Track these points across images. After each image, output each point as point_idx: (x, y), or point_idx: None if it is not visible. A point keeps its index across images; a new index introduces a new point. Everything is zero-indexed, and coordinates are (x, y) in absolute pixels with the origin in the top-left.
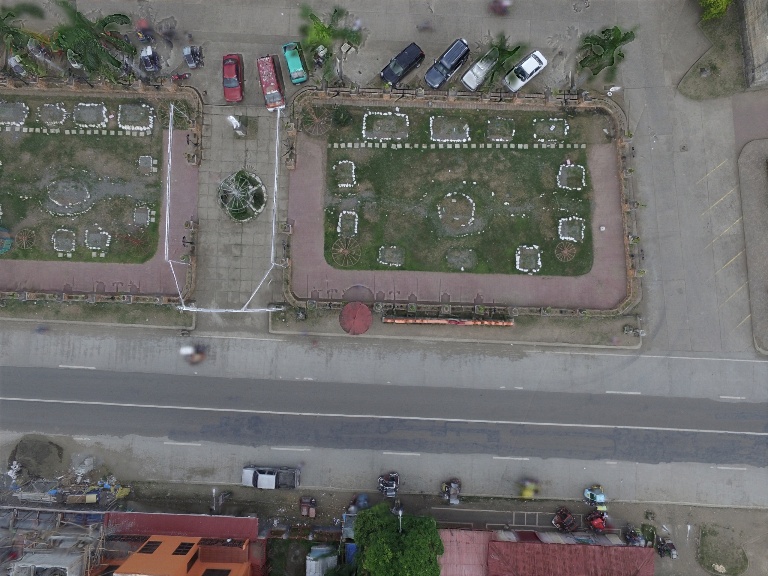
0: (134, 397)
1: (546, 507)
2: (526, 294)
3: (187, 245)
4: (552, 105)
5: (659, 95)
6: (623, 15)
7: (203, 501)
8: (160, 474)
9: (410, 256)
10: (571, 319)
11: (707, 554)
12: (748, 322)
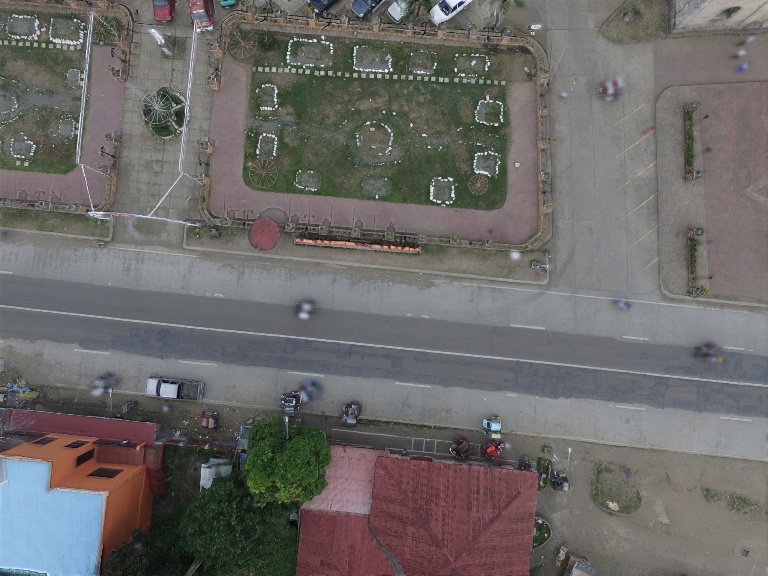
0: (48, 303)
1: (445, 435)
2: (438, 225)
3: (109, 159)
4: (475, 41)
5: (582, 37)
6: None
7: (109, 409)
8: (69, 380)
9: (326, 181)
10: (480, 251)
11: (601, 491)
12: (656, 265)
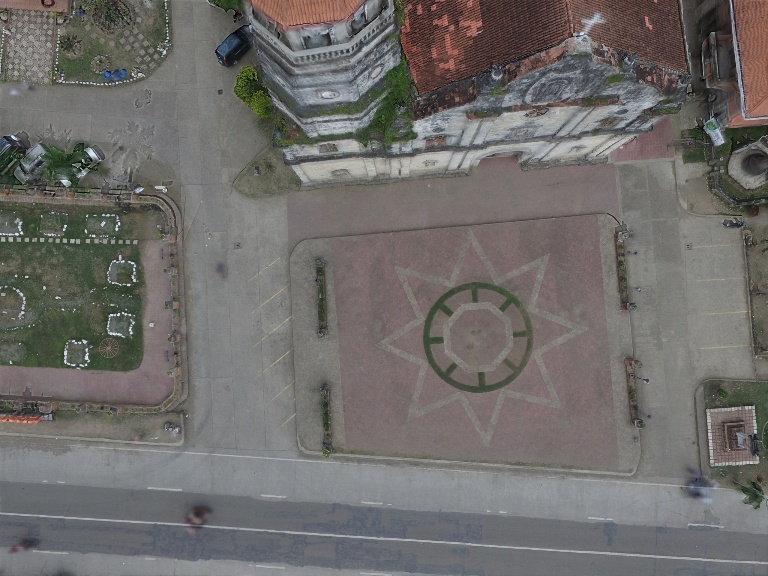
0: None
1: None
2: (75, 388)
3: None
4: (106, 201)
5: (215, 192)
6: (183, 112)
7: None
8: None
9: None
10: None
11: None
12: (293, 421)
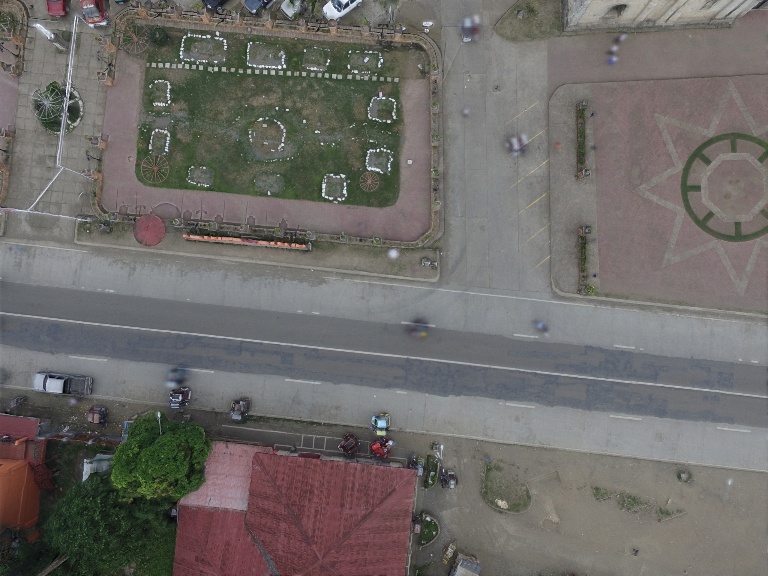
0: None
1: (335, 432)
2: (330, 222)
3: (2, 153)
4: (369, 38)
5: (476, 35)
6: None
7: None
8: None
9: (219, 177)
10: (371, 248)
11: (491, 489)
12: (547, 263)
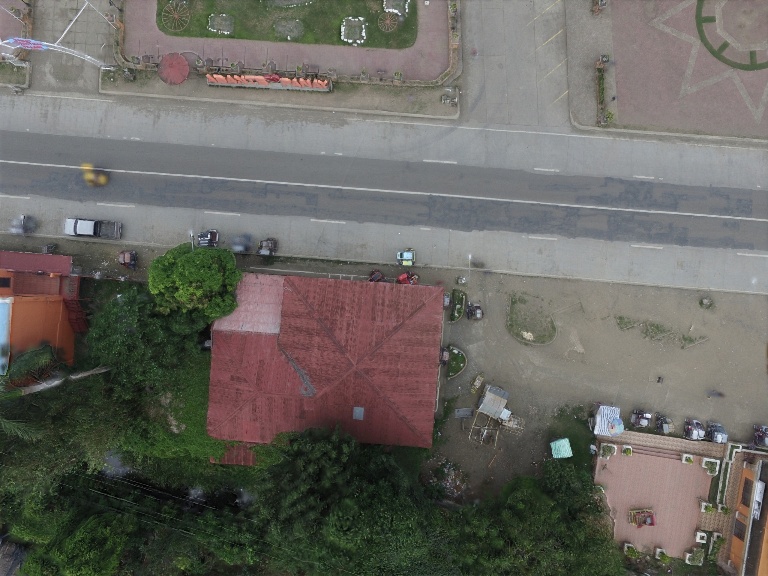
0: None
1: (361, 270)
2: (350, 65)
3: (24, 8)
4: None
5: None
6: None
7: None
8: None
9: (239, 25)
10: (391, 88)
11: (516, 322)
12: (565, 98)
